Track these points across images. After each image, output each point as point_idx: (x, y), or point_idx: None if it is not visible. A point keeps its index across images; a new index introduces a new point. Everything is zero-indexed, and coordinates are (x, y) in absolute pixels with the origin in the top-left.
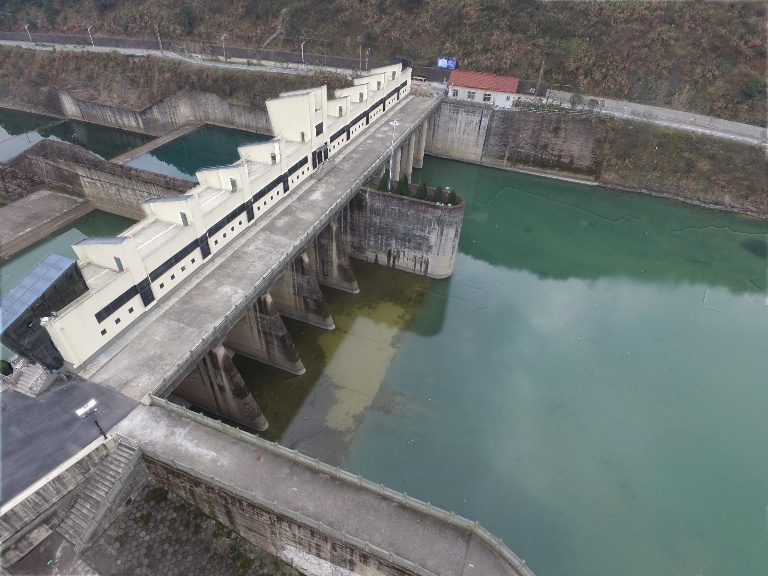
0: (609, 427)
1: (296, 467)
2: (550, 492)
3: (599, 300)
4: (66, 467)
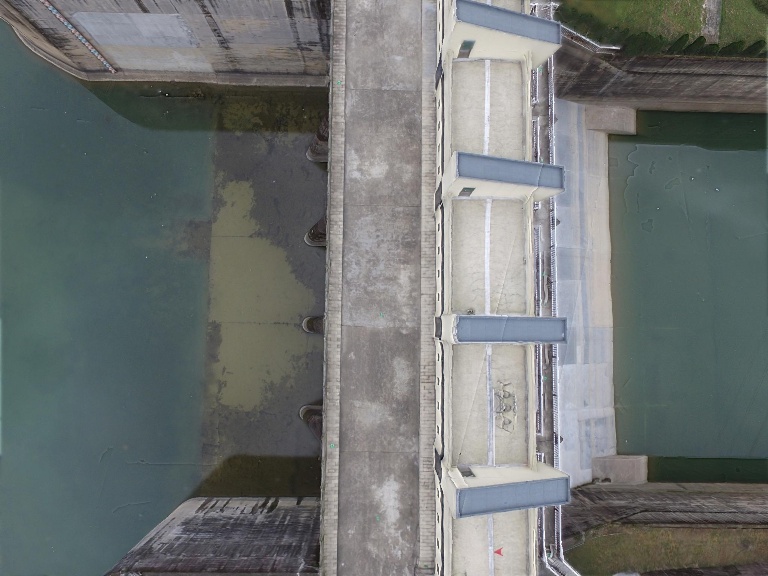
0: None
1: None
2: (6, 198)
3: None
4: None
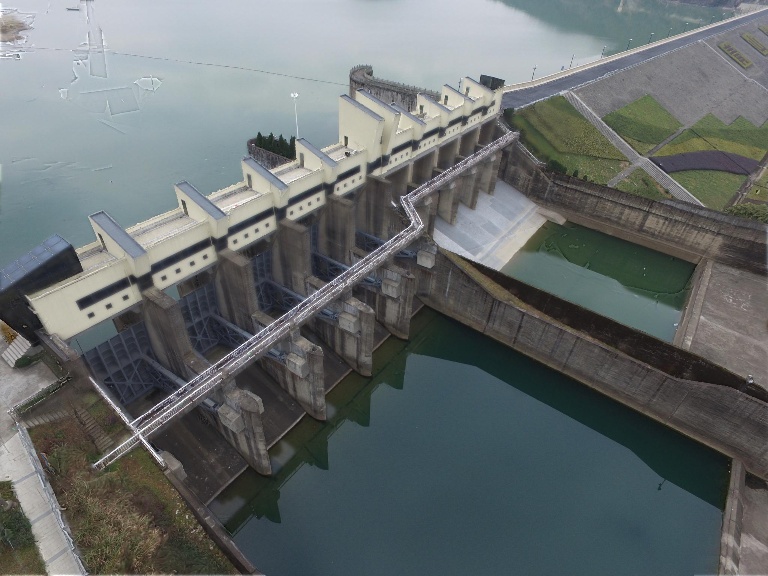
0: None
1: None
2: None
3: (177, 178)
4: None
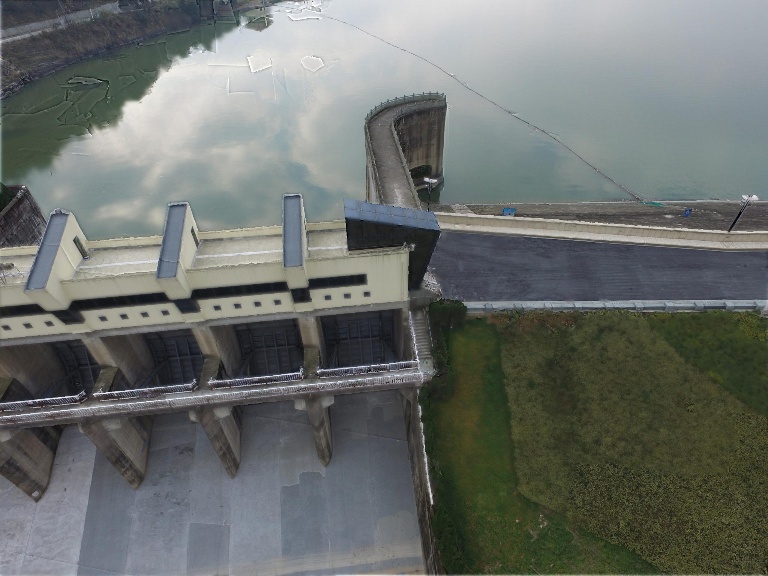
0: (235, 178)
1: (378, 166)
2: (292, 189)
3: (96, 191)
4: (455, 214)
